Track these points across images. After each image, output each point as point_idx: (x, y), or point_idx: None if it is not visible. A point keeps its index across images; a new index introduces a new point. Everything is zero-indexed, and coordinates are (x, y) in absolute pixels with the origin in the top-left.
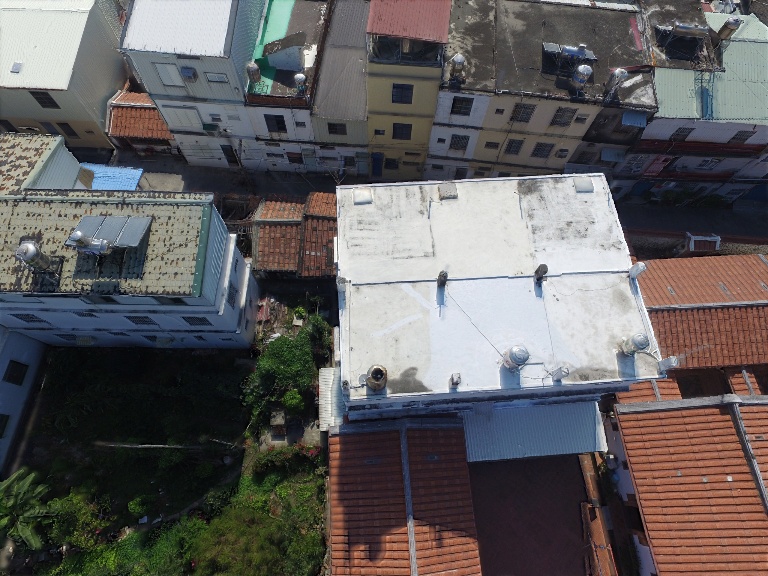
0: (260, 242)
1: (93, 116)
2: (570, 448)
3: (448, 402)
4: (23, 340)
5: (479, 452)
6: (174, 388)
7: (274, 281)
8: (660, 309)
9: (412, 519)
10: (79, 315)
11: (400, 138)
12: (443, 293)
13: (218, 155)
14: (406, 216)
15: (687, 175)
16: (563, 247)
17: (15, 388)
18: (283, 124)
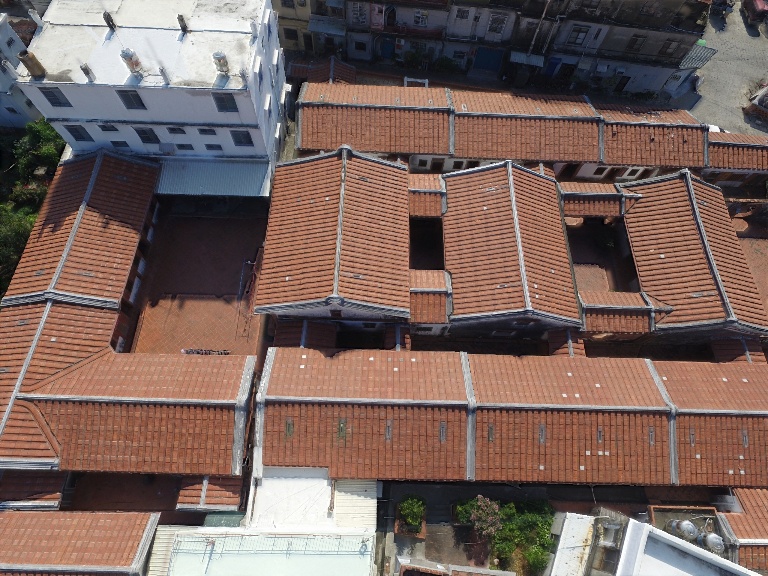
0: None
1: None
2: (239, 192)
3: (120, 122)
4: None
5: (169, 188)
6: None
7: None
8: (335, 105)
9: (85, 205)
10: None
11: None
12: (112, 34)
13: None
14: None
15: (408, 31)
16: (213, 16)
17: None
18: None
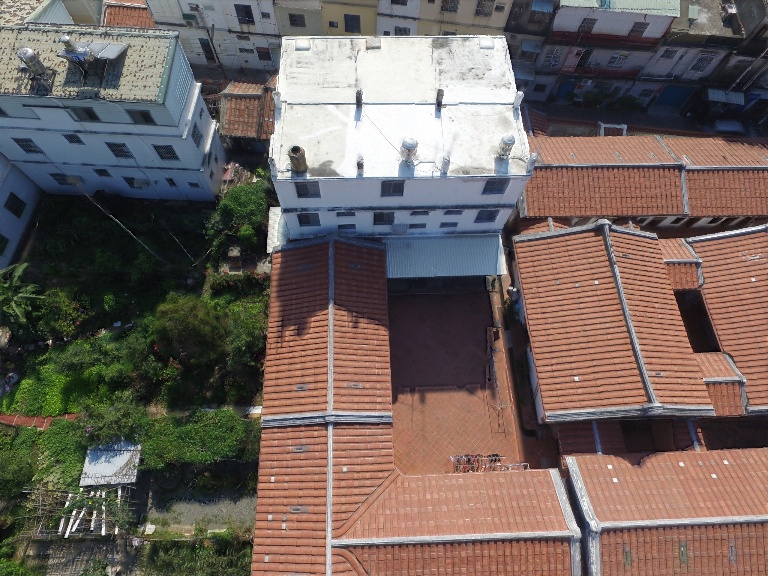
0: (227, 112)
1: (90, 11)
2: (475, 271)
3: (365, 209)
4: (22, 179)
5: (398, 271)
6: (148, 223)
7: (240, 152)
8: (559, 166)
9: (333, 303)
10: (69, 140)
11: (352, 31)
12: (360, 113)
13: (197, 50)
14: (337, 60)
15: (600, 72)
16: (463, 85)
17: (14, 218)
18: (251, 15)
